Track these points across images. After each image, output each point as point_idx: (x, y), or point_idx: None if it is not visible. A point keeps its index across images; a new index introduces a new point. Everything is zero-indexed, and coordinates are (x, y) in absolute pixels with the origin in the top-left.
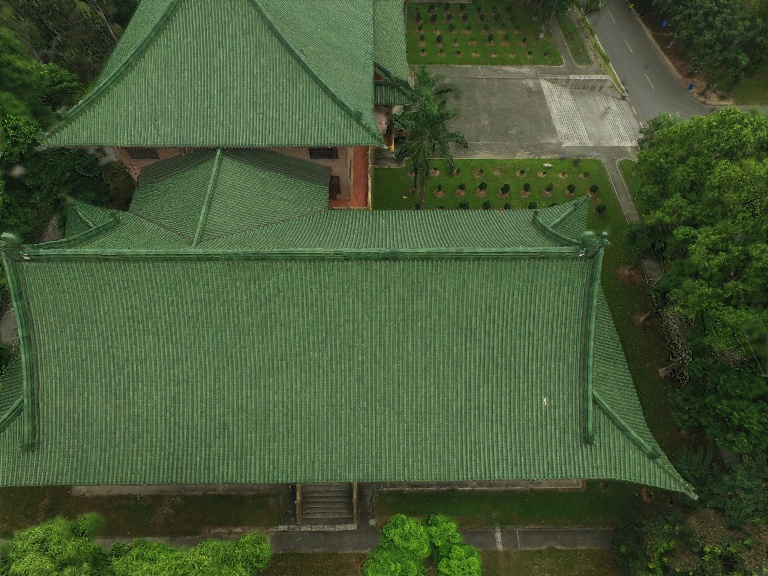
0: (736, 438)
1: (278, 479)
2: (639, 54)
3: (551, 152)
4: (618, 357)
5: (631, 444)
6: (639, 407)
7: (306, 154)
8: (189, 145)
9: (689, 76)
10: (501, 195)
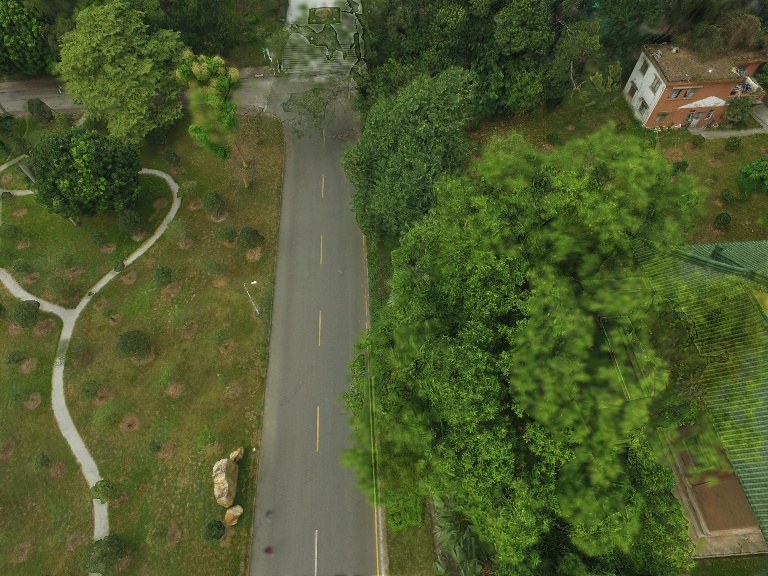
0: None
1: None
2: None
3: None
4: None
5: None
6: None
7: None
8: None
9: None
10: None
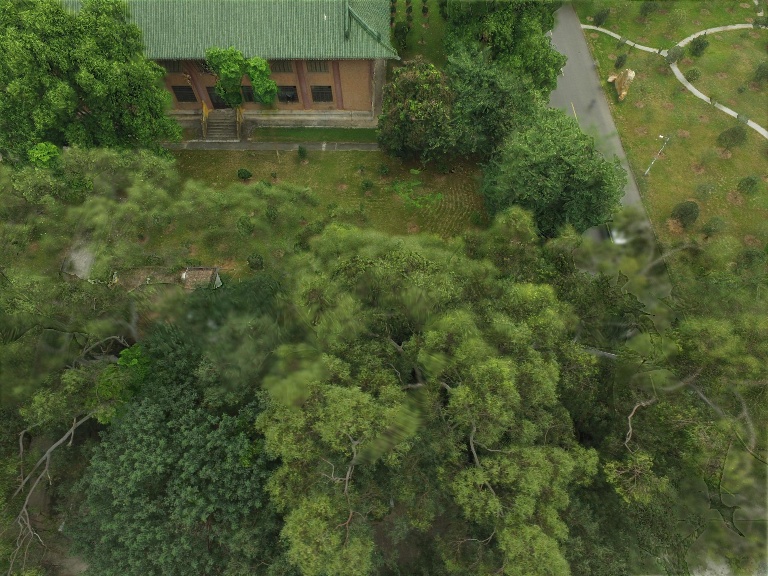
0: None
1: (177, 56)
2: None
3: None
4: (385, 16)
5: (370, 37)
6: (388, 34)
7: None
8: None
9: None
10: None
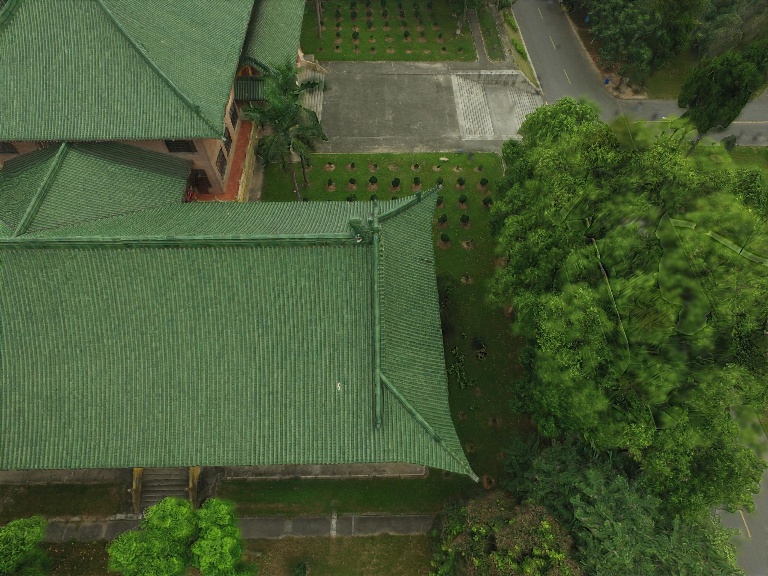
0: (546, 423)
1: (71, 465)
2: (561, 49)
3: (450, 146)
4: (434, 344)
5: (420, 428)
6: (445, 392)
7: (164, 148)
8: (33, 139)
9: (607, 71)
10: (392, 189)
